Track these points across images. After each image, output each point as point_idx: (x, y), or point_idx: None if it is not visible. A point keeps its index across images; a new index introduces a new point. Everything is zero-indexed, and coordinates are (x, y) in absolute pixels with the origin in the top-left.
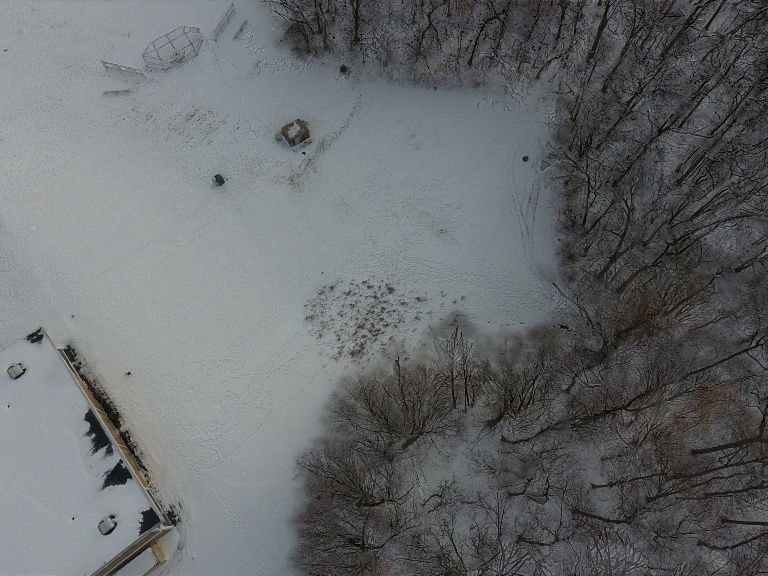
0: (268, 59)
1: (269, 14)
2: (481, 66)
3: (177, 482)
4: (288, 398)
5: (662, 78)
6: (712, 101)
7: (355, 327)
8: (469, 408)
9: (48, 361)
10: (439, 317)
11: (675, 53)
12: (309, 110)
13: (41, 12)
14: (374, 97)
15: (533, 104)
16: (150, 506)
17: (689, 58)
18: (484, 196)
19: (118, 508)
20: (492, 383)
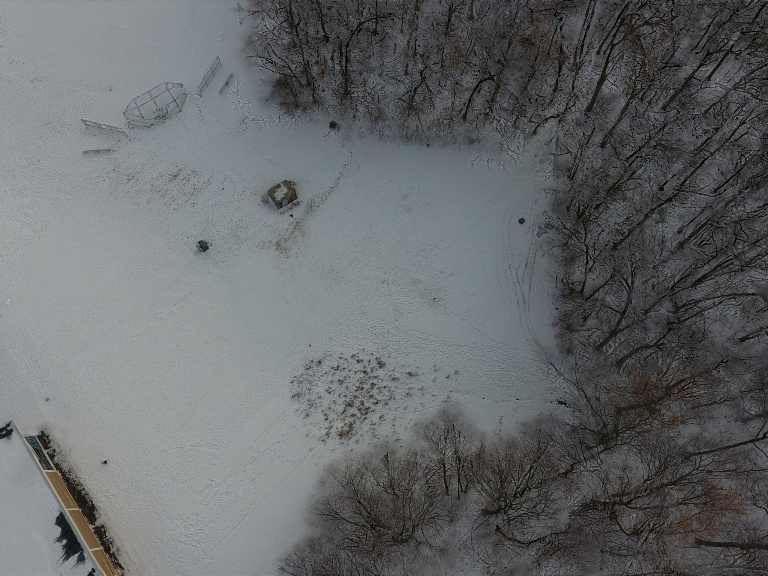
0: (255, 115)
1: (256, 67)
2: (475, 123)
3: None
4: (273, 486)
5: (663, 132)
6: (715, 157)
7: (344, 405)
8: (462, 495)
9: (18, 459)
10: (431, 393)
11: (676, 106)
12: (297, 169)
13: (19, 65)
14: (365, 155)
15: (529, 162)
16: None
17: (691, 111)
18: (478, 262)
19: None
20: (485, 485)
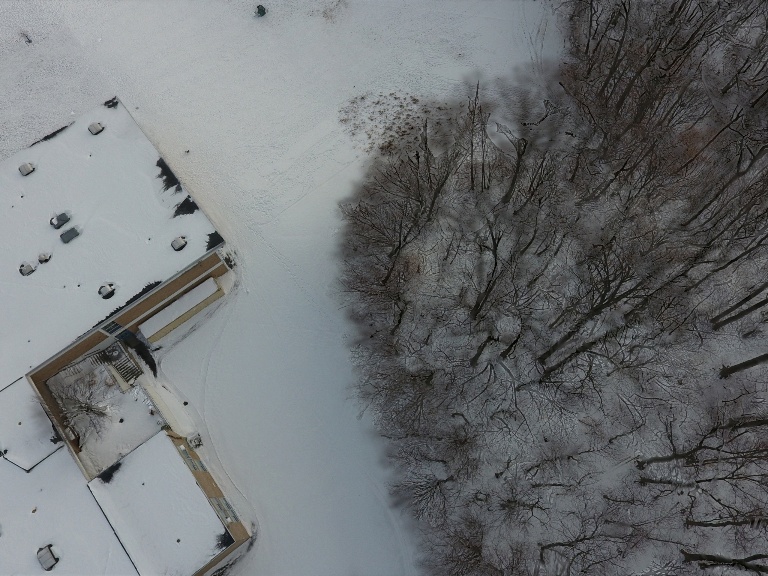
0: None
1: None
2: None
3: (232, 235)
4: (327, 177)
5: None
6: None
7: (384, 129)
8: (485, 190)
9: (123, 121)
10: None
11: None
12: None
13: None
14: None
15: None
16: (215, 230)
17: None
18: (498, 27)
19: (188, 231)
20: (508, 134)
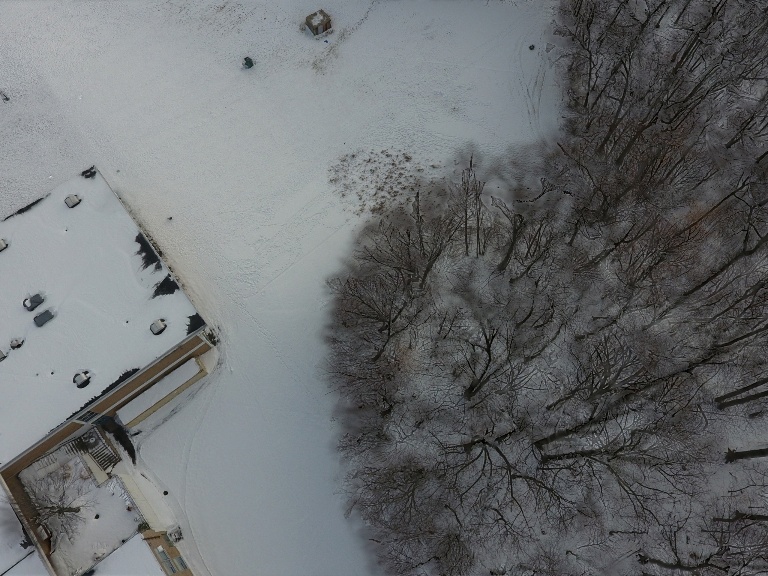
0: None
1: None
2: None
3: (216, 309)
4: (315, 244)
5: None
6: None
7: (375, 189)
8: (480, 256)
9: (101, 193)
10: None
11: None
12: (331, 4)
13: None
14: None
15: (539, 0)
16: (196, 312)
17: None
18: (493, 79)
19: (167, 313)
20: (503, 208)
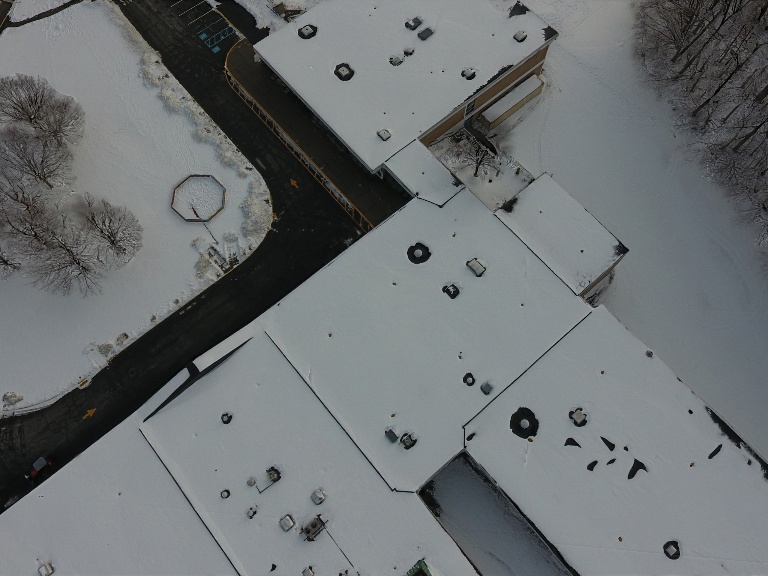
0: None
1: None
2: None
3: None
4: (599, 6)
5: None
6: None
7: None
8: None
9: None
10: None
11: None
12: None
13: None
14: None
15: None
16: (548, 25)
17: None
18: None
19: (525, 27)
20: None
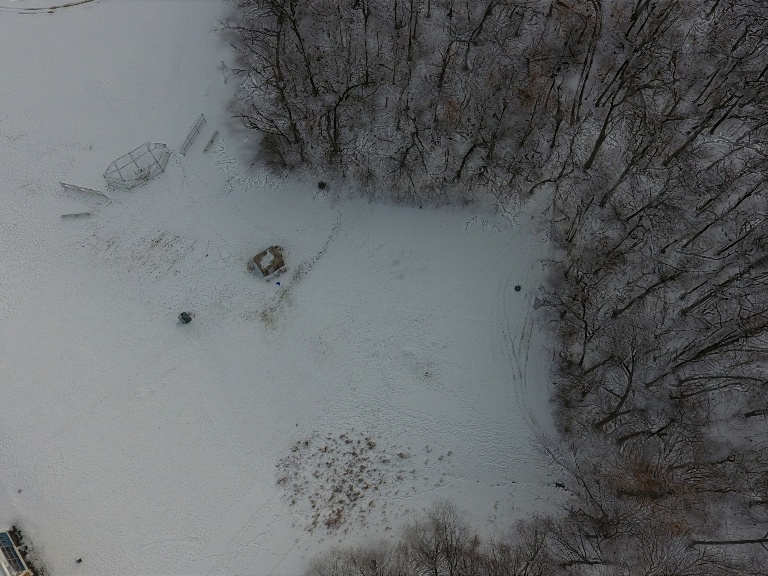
0: (240, 175)
1: (242, 125)
2: (470, 186)
3: None
4: None
5: None
6: None
7: (332, 491)
8: None
9: None
10: (423, 476)
11: (678, 163)
12: (284, 233)
13: None
14: (355, 217)
15: (526, 224)
16: None
17: (693, 167)
18: (473, 333)
19: None
20: None
